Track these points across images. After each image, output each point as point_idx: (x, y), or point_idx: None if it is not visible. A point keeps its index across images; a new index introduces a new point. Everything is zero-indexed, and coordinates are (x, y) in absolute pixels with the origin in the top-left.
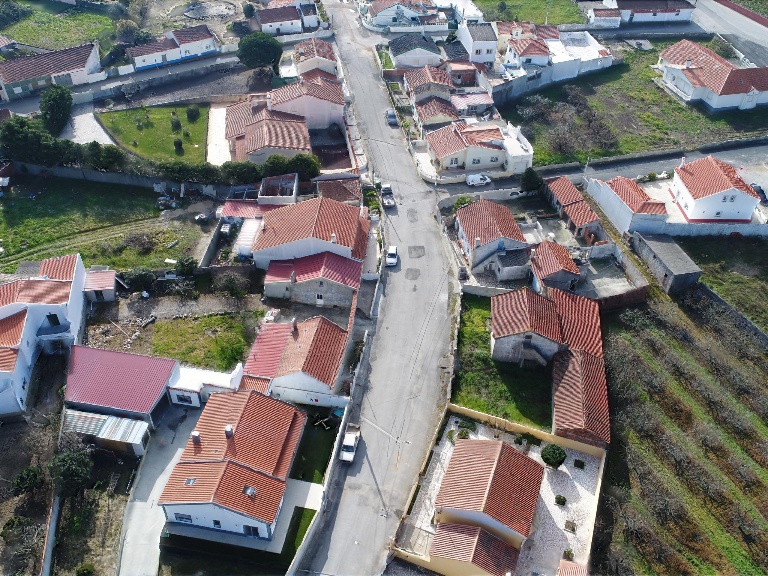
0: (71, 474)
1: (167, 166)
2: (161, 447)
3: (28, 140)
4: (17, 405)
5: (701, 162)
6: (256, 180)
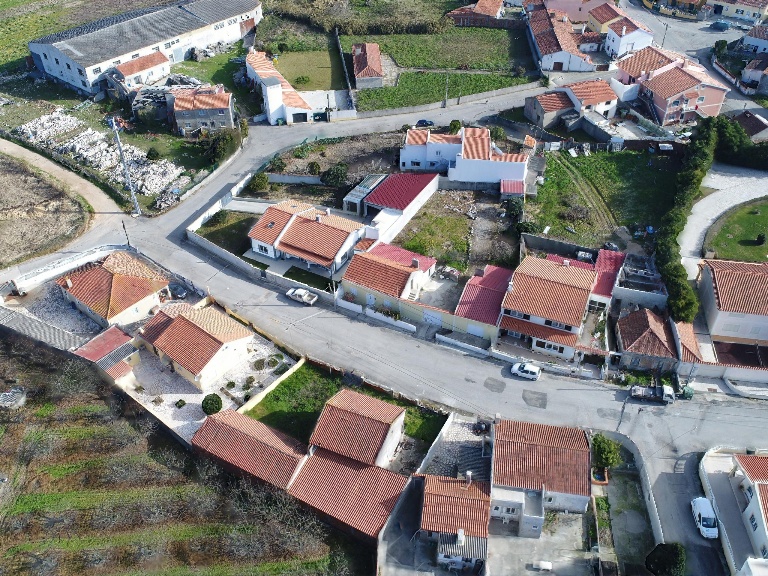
0: None
1: None
2: (350, 219)
3: None
4: None
5: None
6: None
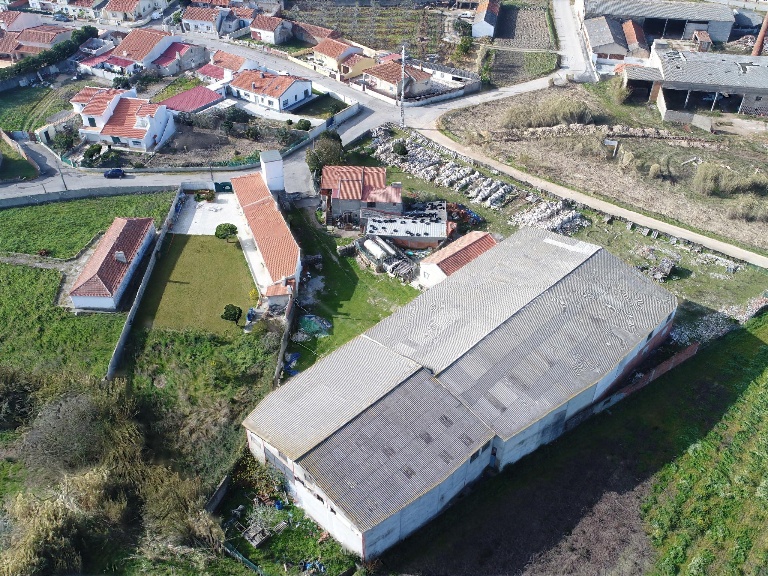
0: None
1: (23, 63)
2: None
3: None
4: (174, 127)
5: None
6: (76, 50)
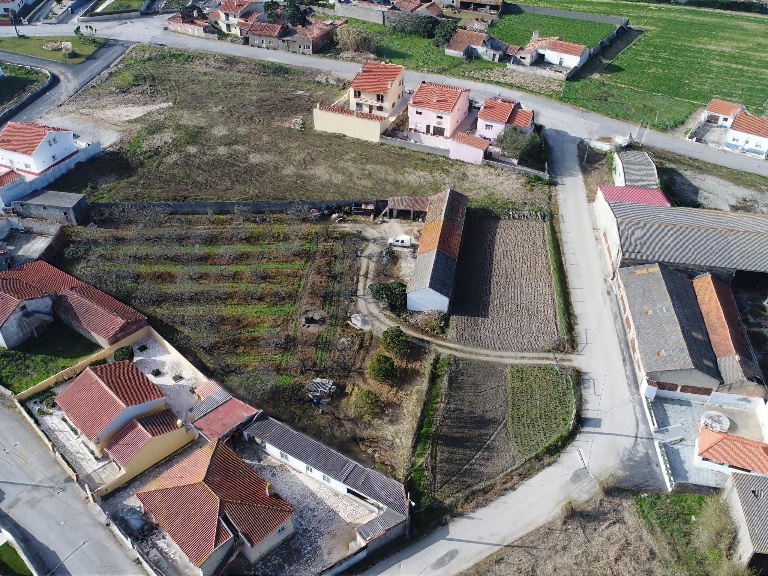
0: None
1: None
2: None
3: None
4: None
5: (7, 130)
6: None
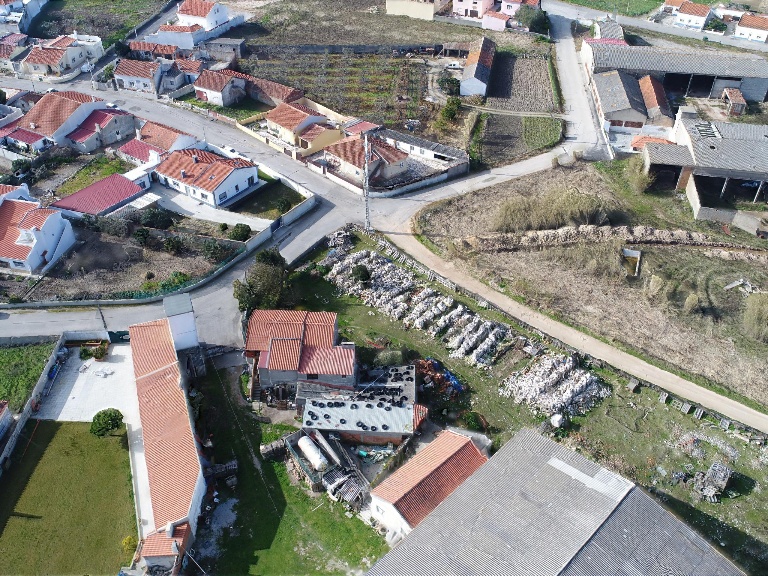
0: (162, 213)
1: None
2: None
3: None
4: (73, 236)
5: (186, 3)
6: None
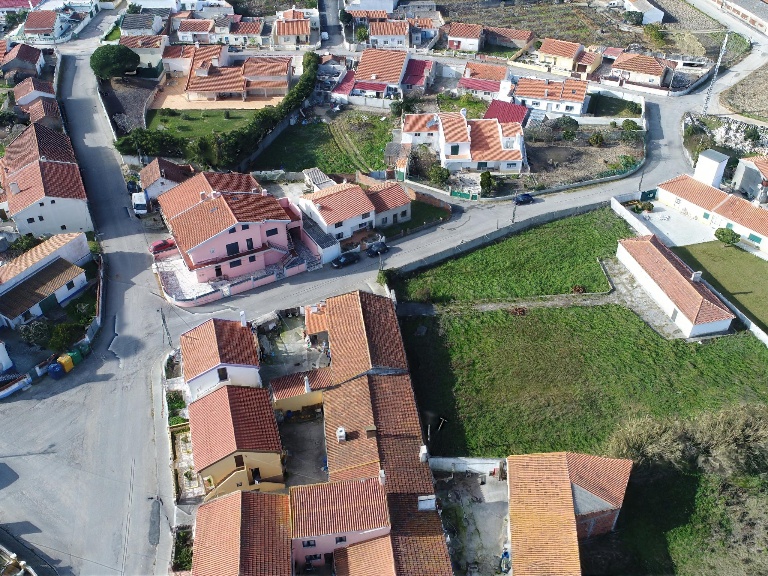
0: None
1: (291, 99)
2: None
3: (239, 138)
4: None
5: None
6: None
